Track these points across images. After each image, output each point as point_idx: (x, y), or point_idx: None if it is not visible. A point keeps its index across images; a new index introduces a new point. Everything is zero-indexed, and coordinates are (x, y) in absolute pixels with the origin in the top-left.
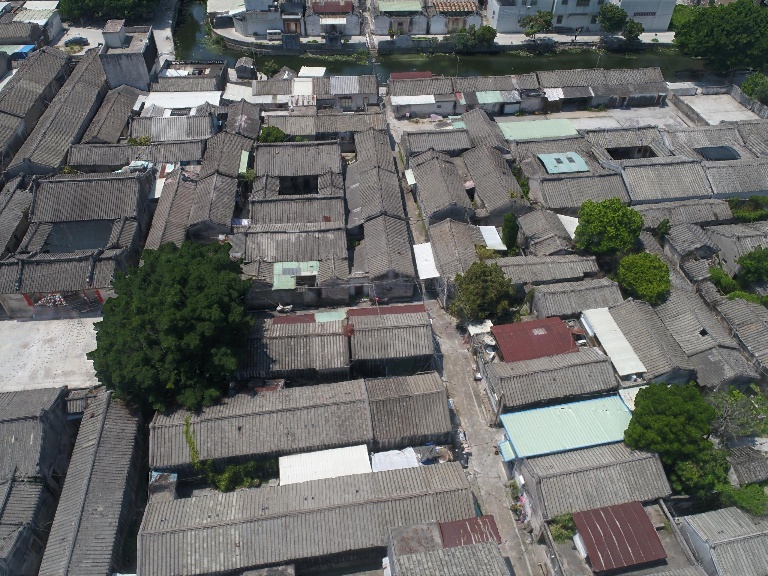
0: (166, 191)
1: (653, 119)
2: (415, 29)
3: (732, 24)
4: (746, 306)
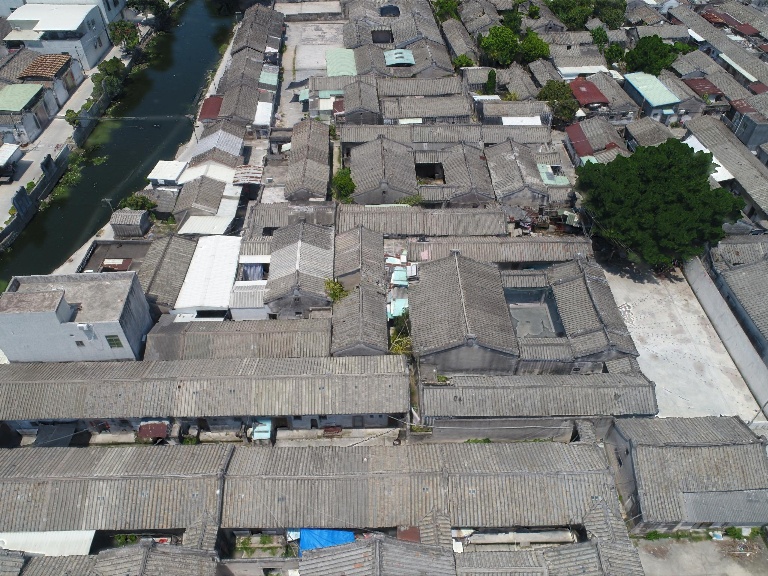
0: (444, 255)
1: (306, 32)
2: (50, 110)
3: None
4: (543, 35)
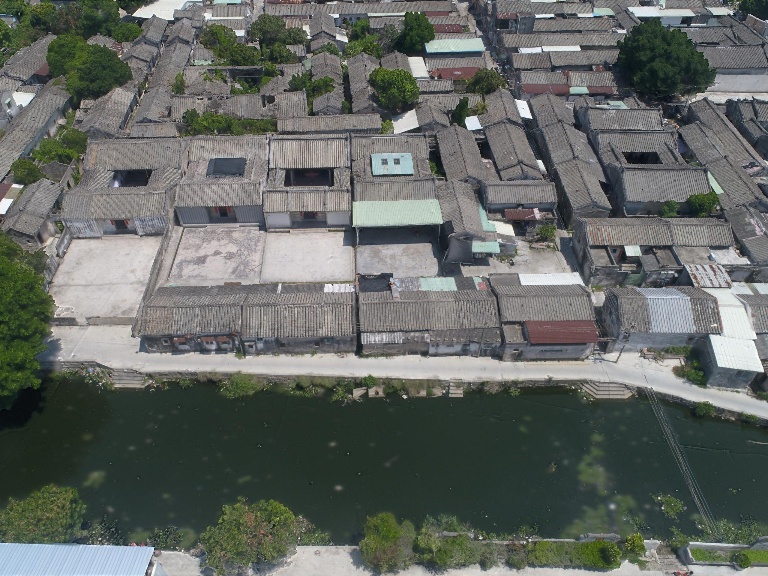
0: (760, 158)
1: (209, 274)
2: None
3: (3, 266)
4: None
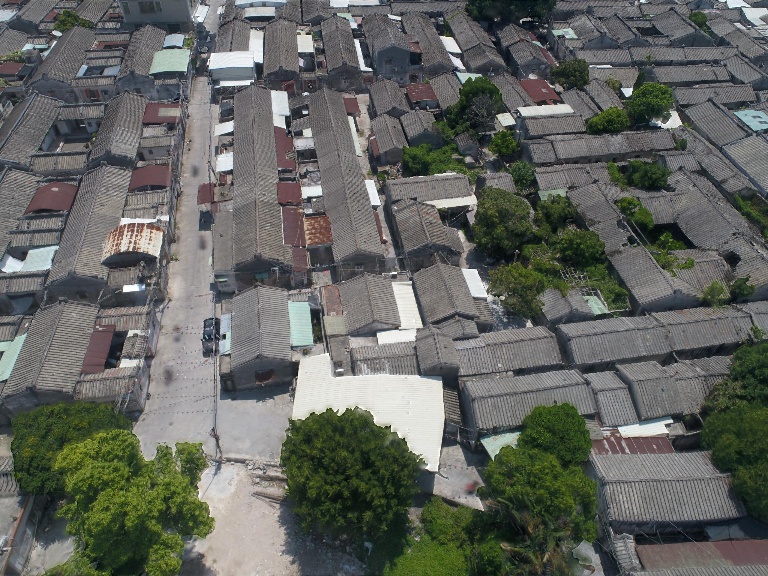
0: None
1: None
2: None
3: None
4: None
